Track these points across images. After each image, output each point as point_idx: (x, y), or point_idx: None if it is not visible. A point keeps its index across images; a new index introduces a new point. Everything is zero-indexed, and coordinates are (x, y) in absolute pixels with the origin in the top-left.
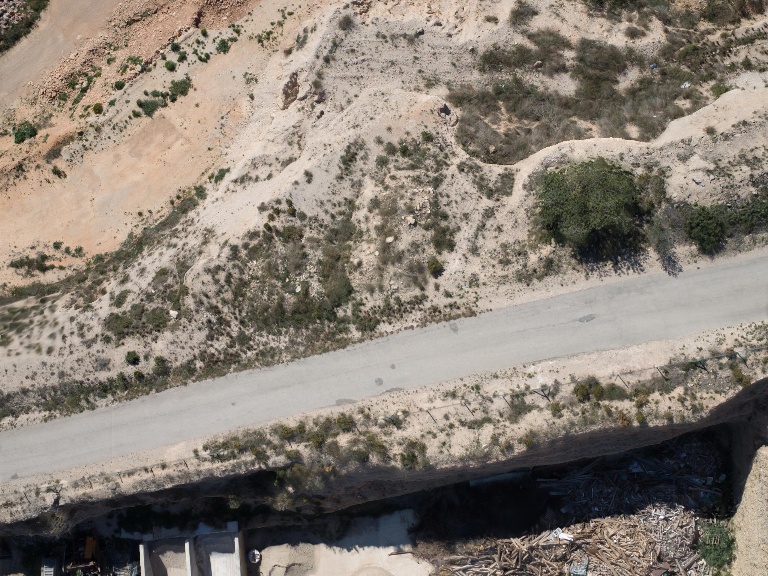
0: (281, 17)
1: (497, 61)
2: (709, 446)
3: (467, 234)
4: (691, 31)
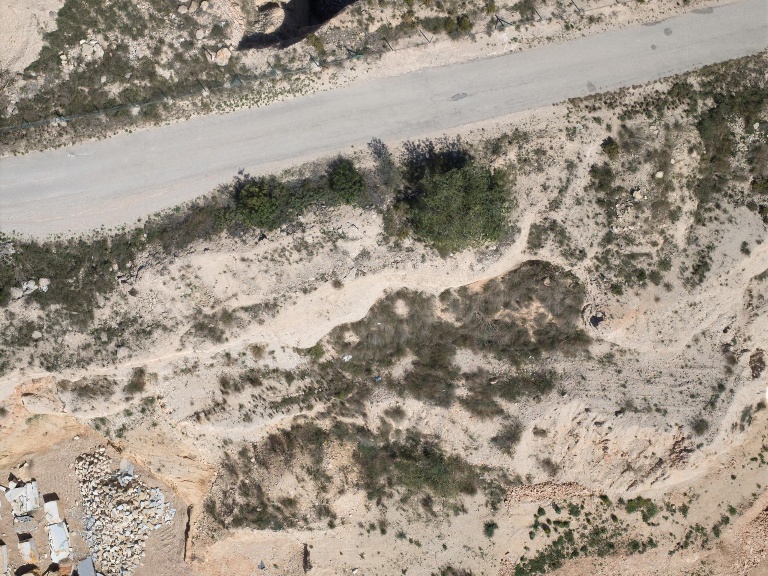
0: (765, 456)
1: (537, 383)
2: (330, 14)
3: (578, 182)
4: (340, 416)
